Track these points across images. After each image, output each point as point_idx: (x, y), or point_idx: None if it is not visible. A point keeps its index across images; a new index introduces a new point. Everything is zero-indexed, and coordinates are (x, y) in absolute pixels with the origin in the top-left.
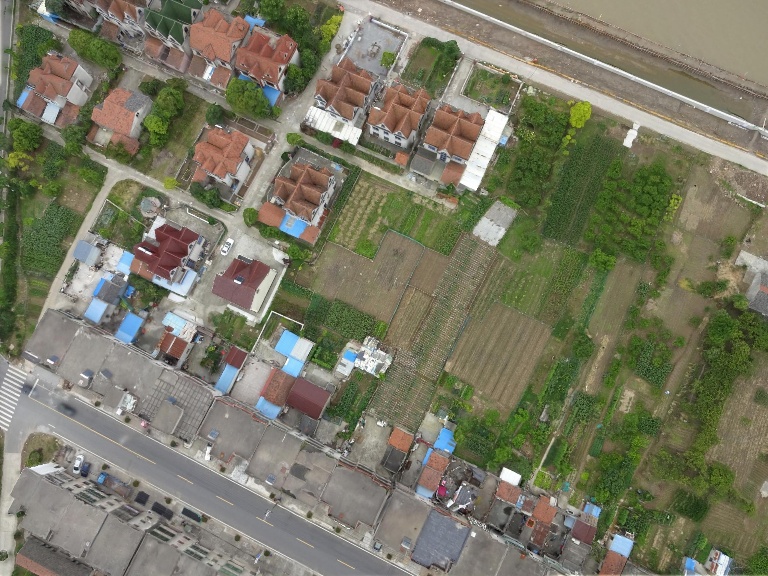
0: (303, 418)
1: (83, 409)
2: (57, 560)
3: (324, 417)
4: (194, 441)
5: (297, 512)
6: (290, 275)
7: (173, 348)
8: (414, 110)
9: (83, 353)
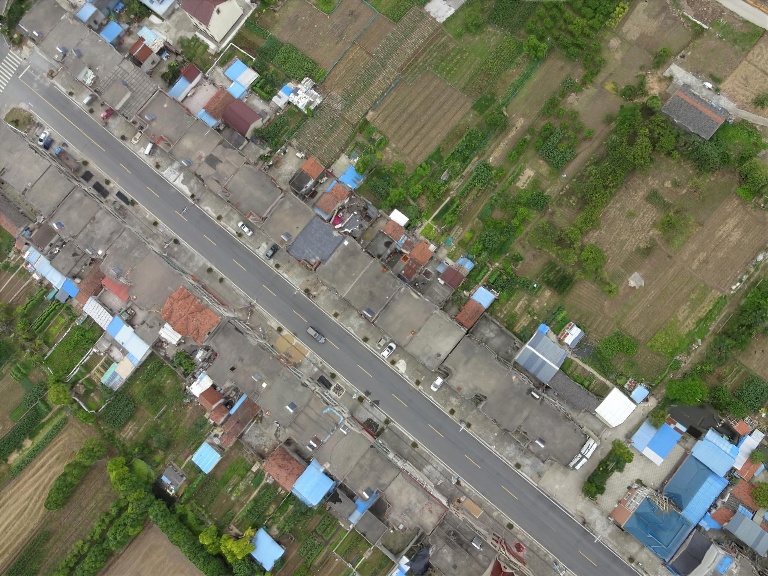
0: (233, 134)
1: (59, 96)
2: (7, 206)
3: (252, 139)
4: (140, 139)
5: (210, 214)
6: (254, 16)
7: (139, 52)
8: None
9: (64, 34)
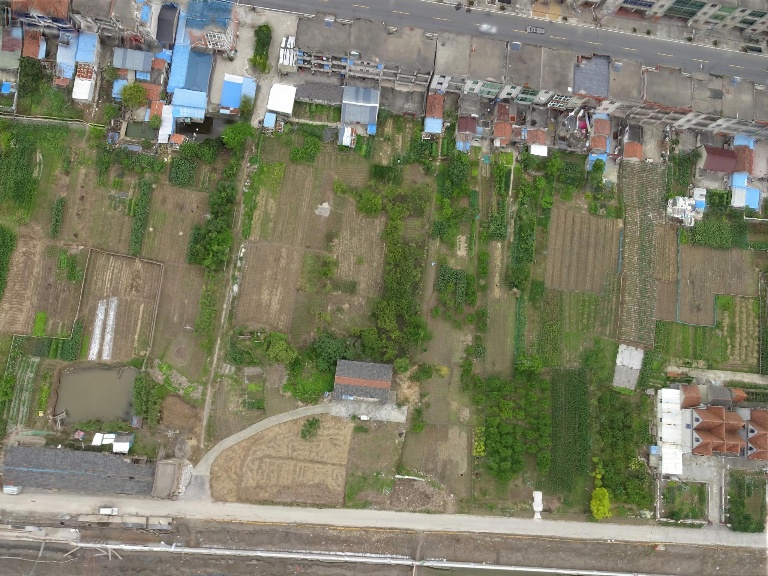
0: None
1: None
2: None
3: None
4: None
5: None
6: None
7: None
8: (765, 435)
9: None
